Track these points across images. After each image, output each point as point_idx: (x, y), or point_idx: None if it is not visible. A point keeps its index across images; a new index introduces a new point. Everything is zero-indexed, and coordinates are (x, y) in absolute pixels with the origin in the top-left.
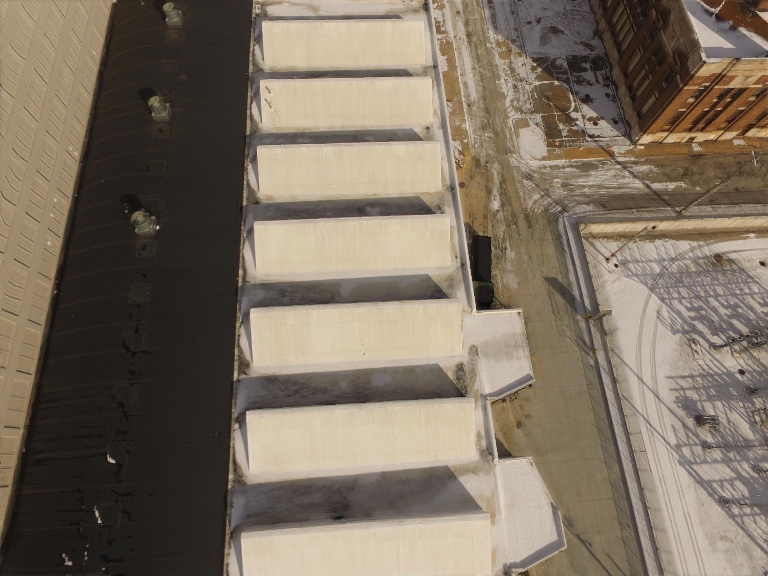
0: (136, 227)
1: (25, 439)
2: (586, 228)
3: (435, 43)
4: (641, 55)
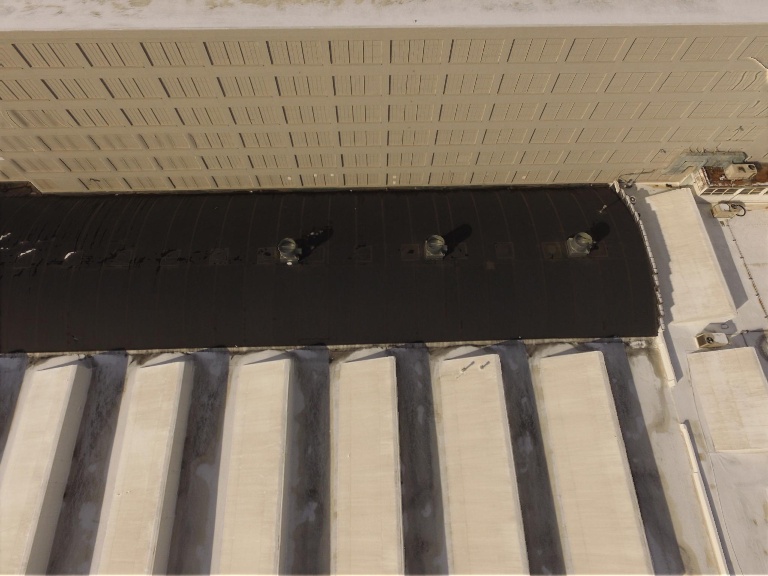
0: None
1: (126, 194)
2: None
3: None
4: None
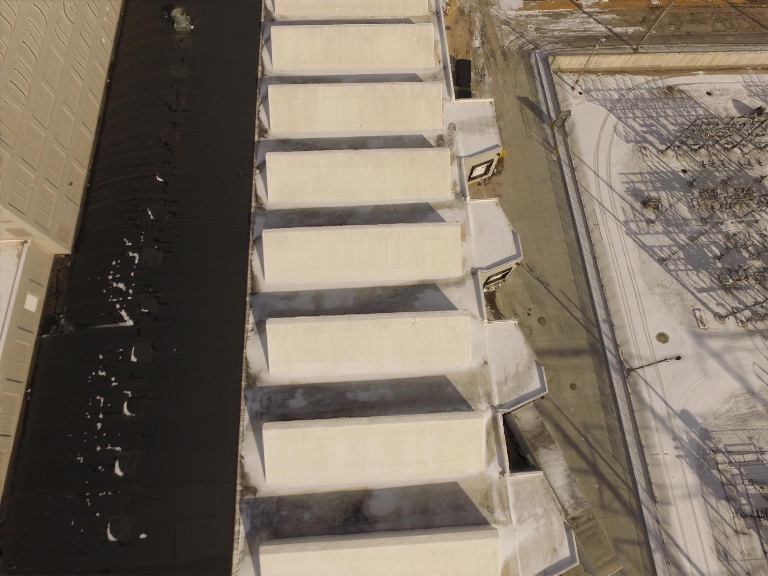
0: (175, 21)
1: (89, 178)
2: (555, 61)
3: None
4: None
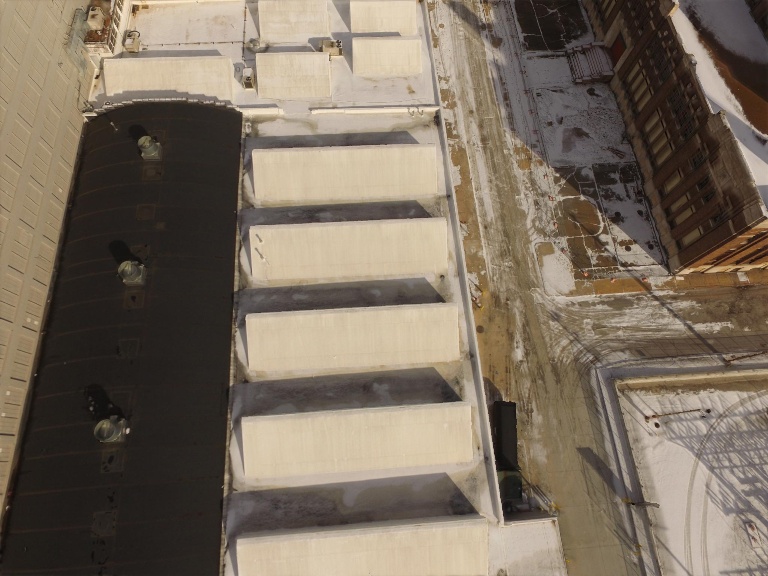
0: None
1: None
2: (622, 382)
3: (448, 168)
4: (681, 179)
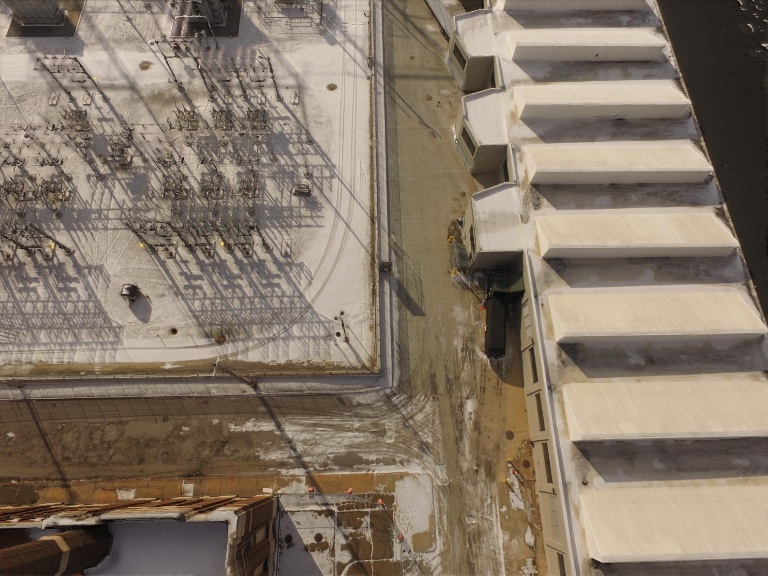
0: None
1: None
2: None
3: None
4: None
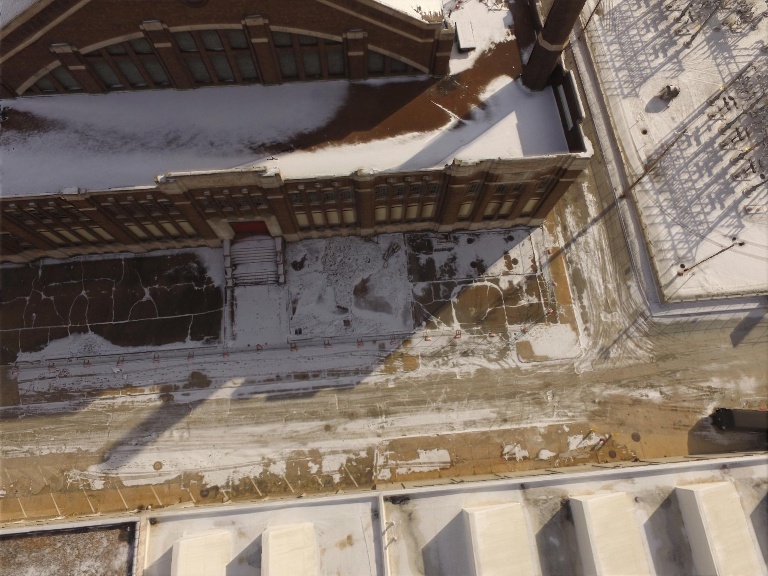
0: None
1: None
2: None
3: None
4: None
